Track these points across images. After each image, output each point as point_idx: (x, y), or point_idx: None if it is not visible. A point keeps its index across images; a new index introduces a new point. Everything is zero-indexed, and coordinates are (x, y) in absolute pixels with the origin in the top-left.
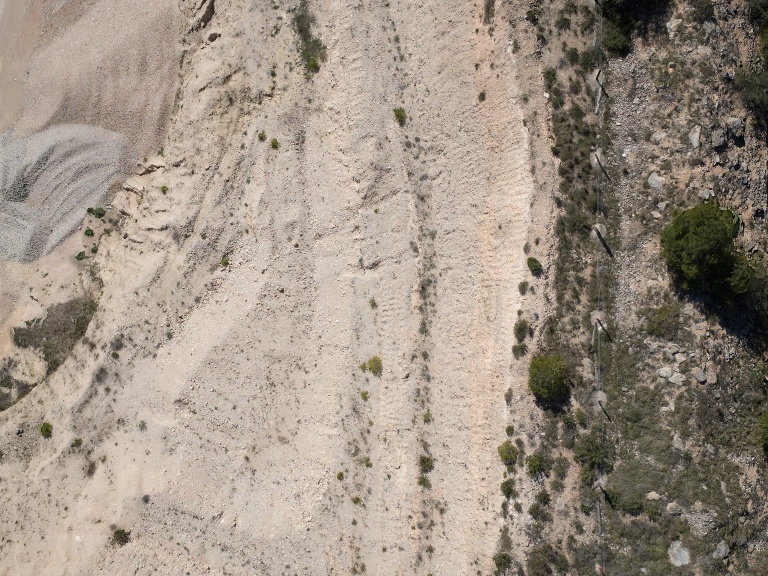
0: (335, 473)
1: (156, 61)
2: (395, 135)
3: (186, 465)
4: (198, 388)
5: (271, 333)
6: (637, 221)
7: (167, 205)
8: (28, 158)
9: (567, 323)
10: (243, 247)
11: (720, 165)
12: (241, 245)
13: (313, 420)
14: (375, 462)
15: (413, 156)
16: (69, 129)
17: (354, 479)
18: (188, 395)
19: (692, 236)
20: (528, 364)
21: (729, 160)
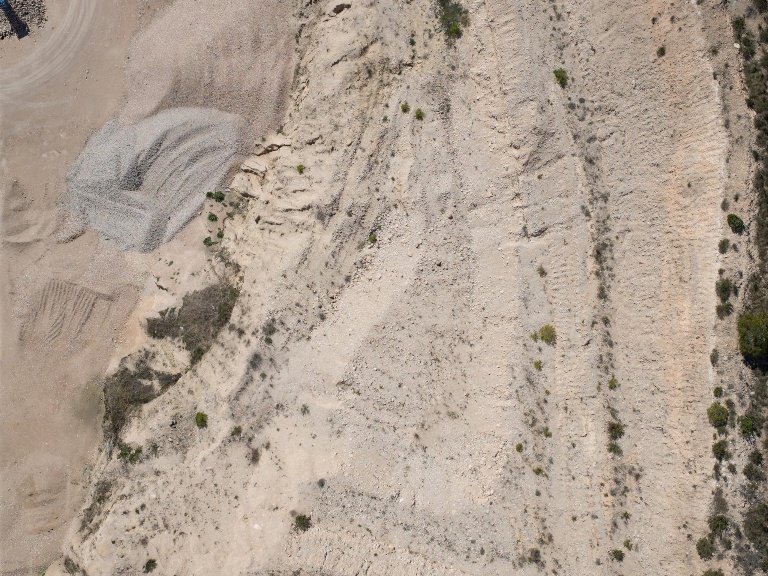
0: (513, 445)
1: (270, 37)
2: (557, 97)
3: (356, 446)
4: (361, 368)
5: (432, 308)
6: None
7: (306, 184)
8: (140, 145)
9: None
10: (392, 222)
11: None
12: (390, 220)
13: (483, 393)
14: (555, 431)
15: (578, 118)
16: (180, 113)
17: (534, 450)
18: (351, 376)
19: None
20: (734, 323)
21: None
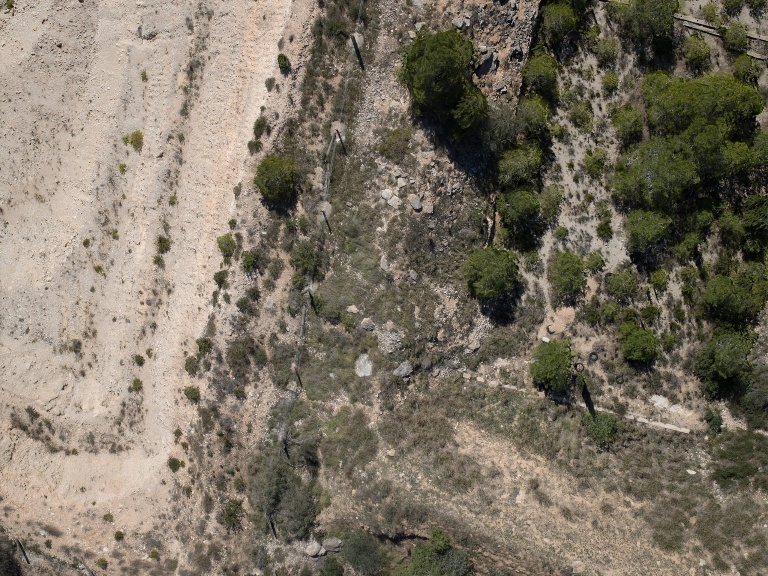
0: (82, 239)
1: None
2: None
3: None
4: None
5: (42, 88)
6: (394, 38)
7: None
8: None
9: (307, 128)
10: None
11: None
12: None
13: (71, 184)
14: (122, 235)
15: None
16: None
17: (99, 248)
18: None
19: (424, 60)
20: (260, 162)
21: None
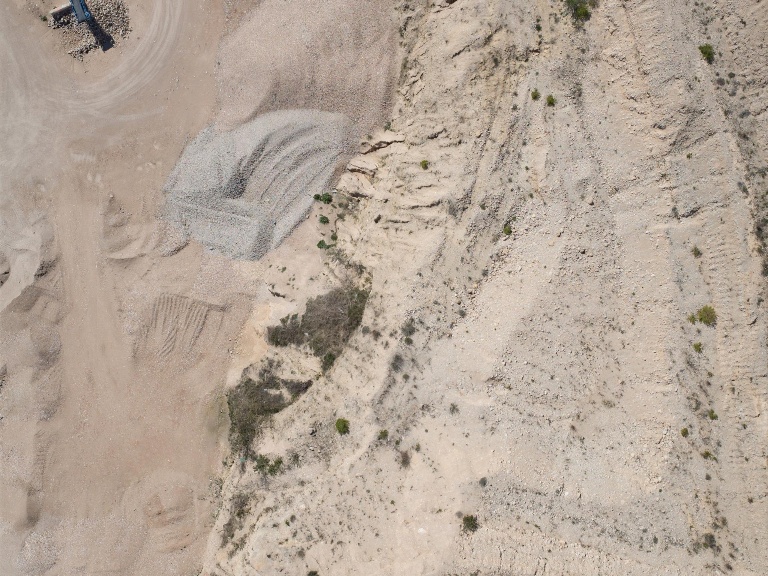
0: (678, 430)
1: (373, 32)
2: (704, 74)
3: (513, 442)
4: (510, 363)
5: (579, 297)
6: None
7: (432, 180)
8: (241, 152)
9: None
10: (528, 212)
11: None
12: (525, 211)
13: (639, 380)
14: (721, 414)
15: (728, 93)
16: (281, 116)
17: (700, 434)
18: (502, 371)
19: None
20: None
21: None
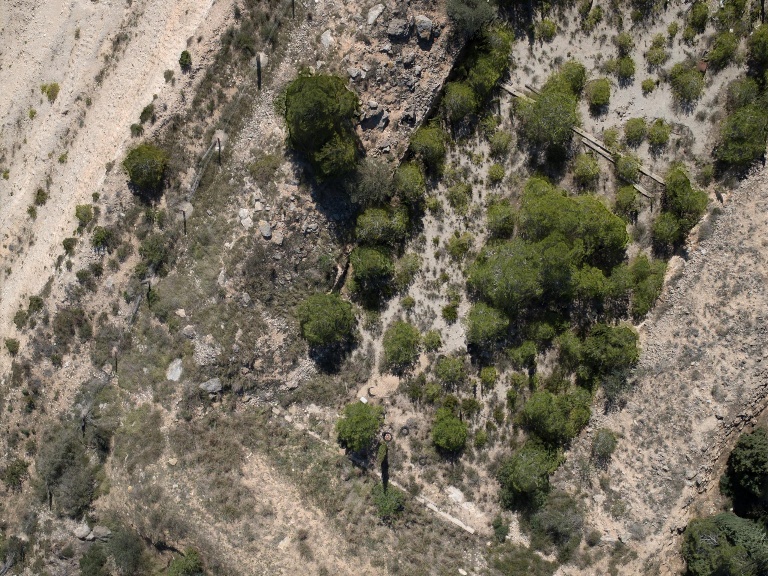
0: None
1: None
2: None
3: None
4: None
5: None
6: (295, 68)
7: None
8: None
9: (192, 128)
10: None
11: (388, 54)
12: None
13: None
14: (12, 177)
15: None
16: None
17: None
18: None
19: (300, 97)
20: (137, 146)
21: (401, 55)
